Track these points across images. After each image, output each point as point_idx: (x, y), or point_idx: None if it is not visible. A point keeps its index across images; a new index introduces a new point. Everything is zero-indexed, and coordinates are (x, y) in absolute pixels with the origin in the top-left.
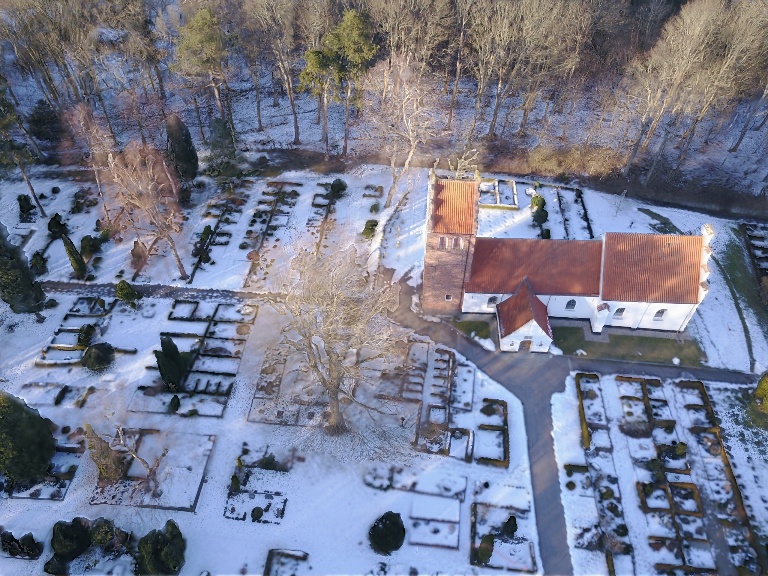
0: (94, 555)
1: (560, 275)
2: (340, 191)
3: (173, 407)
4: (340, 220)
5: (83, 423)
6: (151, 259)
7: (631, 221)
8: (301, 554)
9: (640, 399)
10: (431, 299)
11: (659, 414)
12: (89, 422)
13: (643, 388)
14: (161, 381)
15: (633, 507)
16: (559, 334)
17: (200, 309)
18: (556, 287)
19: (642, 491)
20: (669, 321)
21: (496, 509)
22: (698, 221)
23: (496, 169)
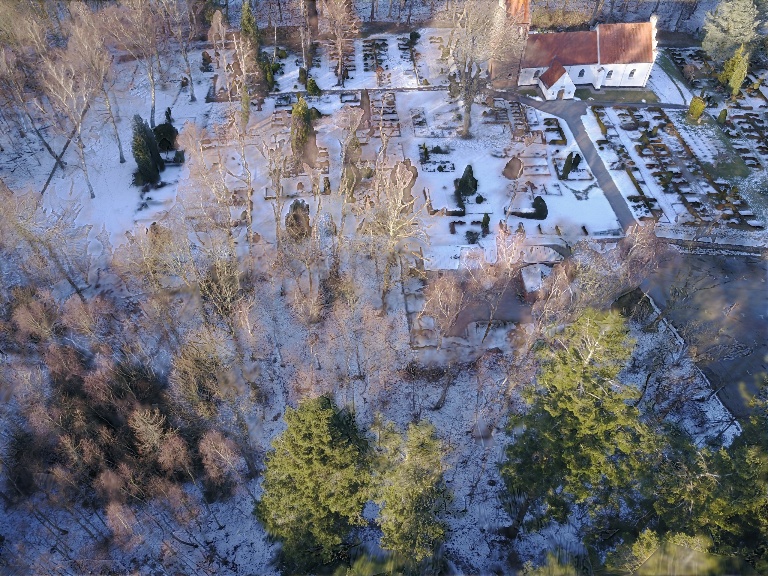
0: (361, 190)
1: (575, 53)
2: (417, 38)
3: (372, 132)
4: (422, 55)
5: (320, 146)
6: None
7: None
8: None
9: (628, 115)
10: None
11: (640, 120)
12: (323, 145)
13: (629, 111)
14: None
15: (635, 155)
16: (576, 92)
17: None
18: (573, 60)
19: (639, 148)
20: (637, 79)
21: None
22: None
23: None
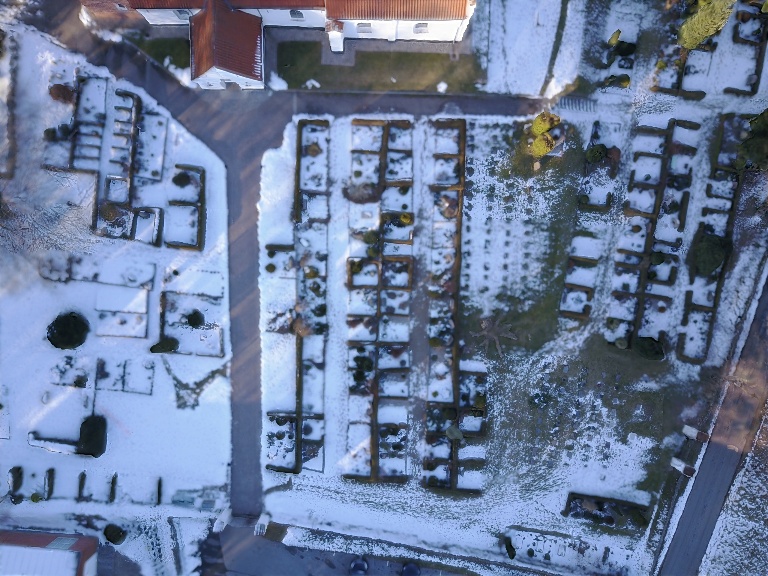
0: None
1: None
2: None
3: None
4: None
5: None
6: None
7: None
8: None
9: (376, 152)
10: (97, 8)
11: (395, 171)
12: None
13: (383, 136)
14: None
15: (338, 285)
16: (286, 55)
17: None
18: None
19: (349, 270)
20: (437, 32)
21: (187, 296)
22: None
23: None
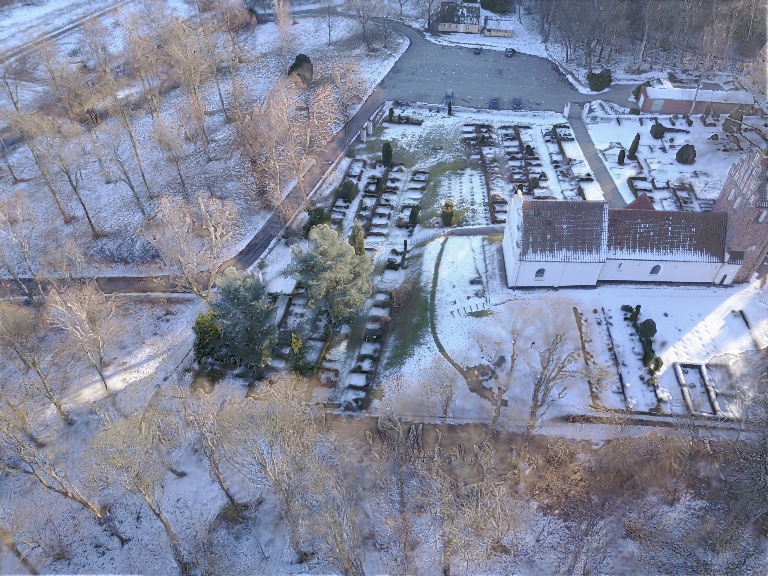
0: None
1: None
2: None
3: None
4: None
5: None
6: None
7: (529, 360)
8: None
9: None
10: None
11: None
12: None
13: None
14: None
15: (550, 174)
16: None
17: None
18: None
19: None
20: None
21: None
22: None
23: None
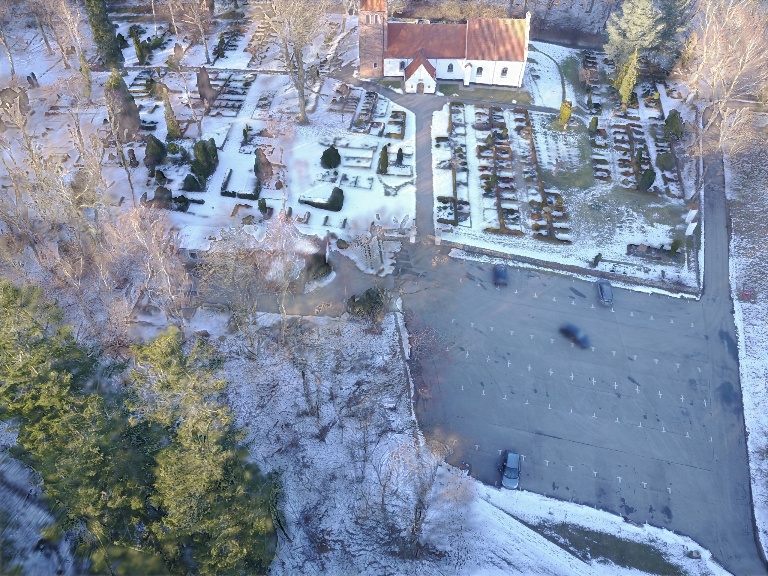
0: (167, 165)
1: (442, 46)
2: None
3: (207, 110)
4: None
5: (153, 120)
6: (186, 56)
7: None
8: (282, 164)
9: (487, 115)
10: (365, 67)
11: (497, 121)
12: (157, 120)
13: (490, 110)
14: (198, 103)
15: (472, 156)
16: (443, 87)
17: (220, 76)
18: (439, 54)
19: (478, 148)
20: (511, 78)
21: (394, 154)
22: (552, 46)
23: (418, 15)
